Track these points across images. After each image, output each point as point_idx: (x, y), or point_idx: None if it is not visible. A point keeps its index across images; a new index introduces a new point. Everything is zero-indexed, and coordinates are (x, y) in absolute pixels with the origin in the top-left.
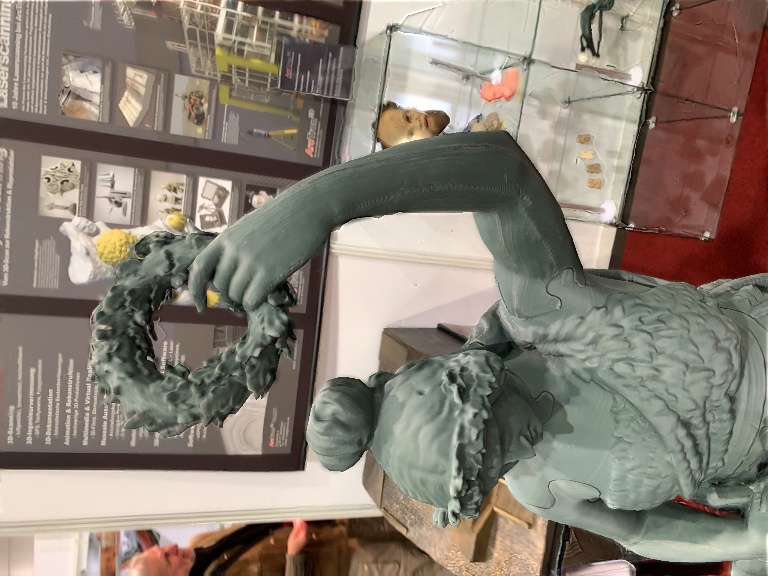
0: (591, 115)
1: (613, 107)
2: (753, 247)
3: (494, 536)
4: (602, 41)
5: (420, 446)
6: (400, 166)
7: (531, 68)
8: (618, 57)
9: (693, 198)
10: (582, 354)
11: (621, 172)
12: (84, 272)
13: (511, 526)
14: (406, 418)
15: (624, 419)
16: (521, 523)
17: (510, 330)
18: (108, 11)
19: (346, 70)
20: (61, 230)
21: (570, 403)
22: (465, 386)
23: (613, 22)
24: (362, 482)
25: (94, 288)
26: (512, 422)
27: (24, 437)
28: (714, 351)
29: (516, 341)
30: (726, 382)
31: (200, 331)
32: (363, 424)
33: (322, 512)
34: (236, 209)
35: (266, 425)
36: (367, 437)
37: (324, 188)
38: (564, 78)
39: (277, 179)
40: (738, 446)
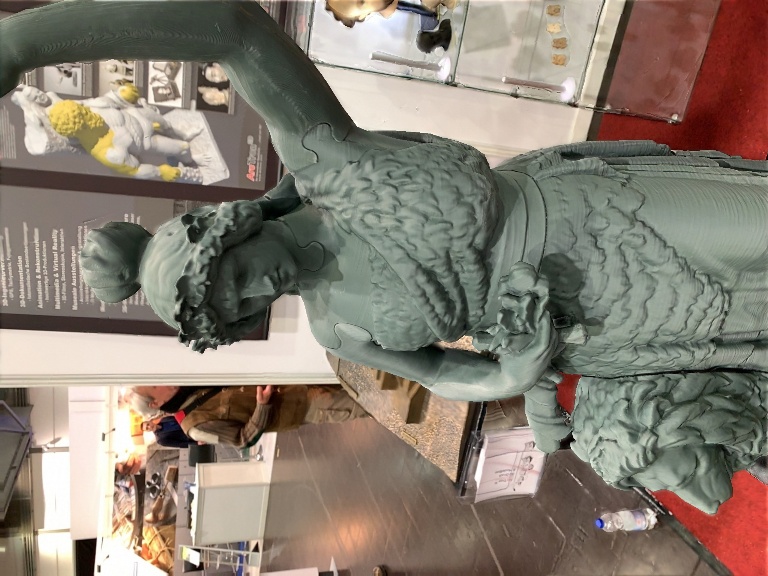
0: None
1: None
2: (716, 131)
3: (427, 401)
4: None
5: (159, 279)
6: (88, 11)
7: None
8: None
9: (681, 79)
10: (339, 206)
11: (603, 49)
12: (40, 143)
13: None
14: (153, 255)
15: (377, 267)
16: None
17: (295, 185)
18: None
19: None
20: (13, 100)
21: (340, 253)
22: (198, 227)
23: None
24: (326, 353)
25: (52, 159)
26: (255, 263)
27: (0, 299)
28: (454, 205)
29: None
30: (467, 235)
31: (159, 205)
32: (121, 260)
33: (288, 378)
34: (189, 81)
35: None
36: (129, 272)
37: (4, 30)
38: None
39: None
40: (496, 297)
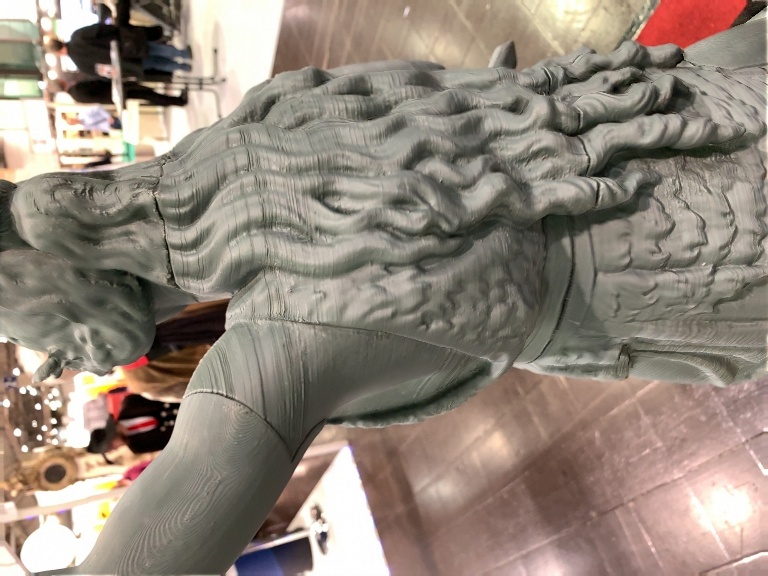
0: None
1: None
2: None
3: None
4: None
5: None
6: None
7: None
8: None
9: None
10: None
11: None
12: None
13: None
14: None
15: None
16: None
17: None
18: None
19: None
20: None
21: None
22: None
23: None
24: None
25: None
26: None
27: None
28: None
29: None
30: None
31: None
32: None
33: None
34: None
35: None
36: None
37: None
38: None
39: None
40: None
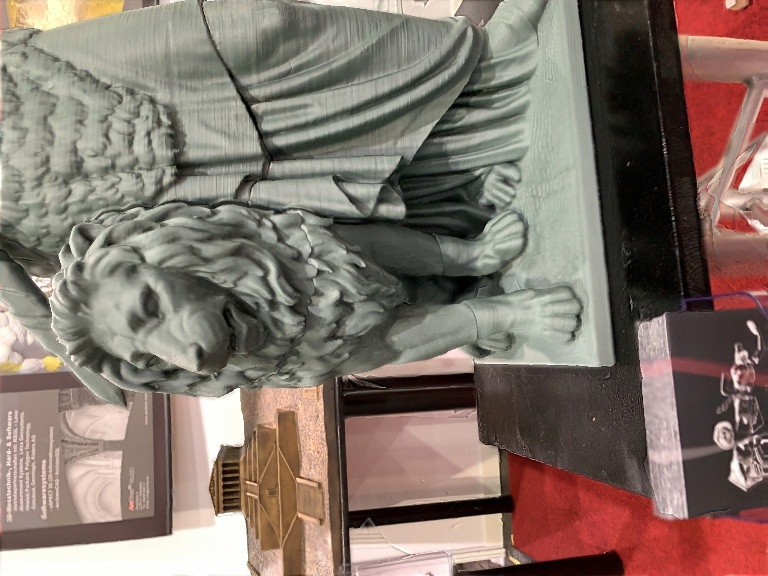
0: None
1: None
2: None
3: (304, 548)
4: None
5: None
6: None
7: None
8: None
9: None
10: None
11: None
12: None
13: (313, 530)
14: None
15: None
16: (316, 522)
17: None
18: None
19: None
20: None
21: None
22: None
23: None
24: None
25: None
26: None
27: None
28: None
29: None
30: None
31: (43, 396)
32: None
33: None
34: None
35: (123, 487)
36: None
37: None
38: None
39: None
40: None
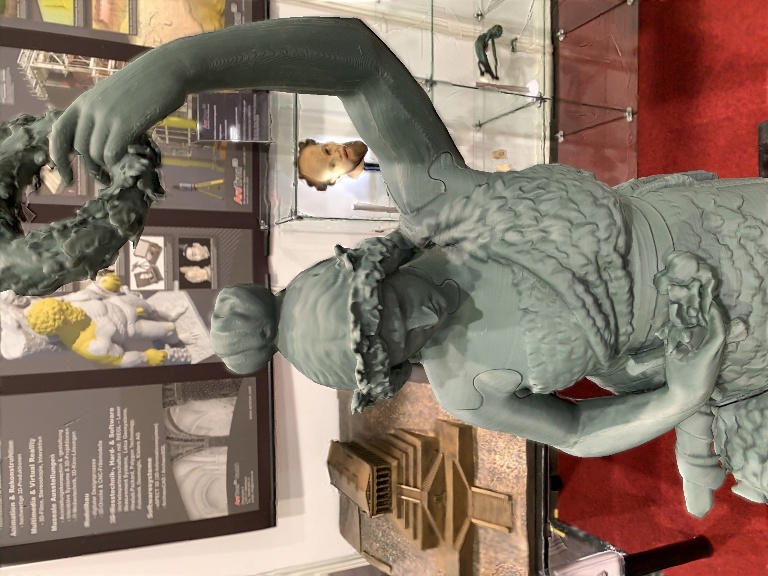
0: (503, 136)
1: (522, 127)
2: None
3: (477, 550)
4: (498, 65)
5: (319, 317)
6: (250, 31)
7: (434, 89)
8: (516, 78)
9: None
10: (474, 232)
11: None
12: (17, 346)
13: (492, 535)
14: (303, 298)
15: (525, 288)
16: (501, 529)
17: (409, 234)
18: (20, 86)
19: (262, 115)
20: None
21: (475, 289)
22: (355, 254)
23: (505, 48)
24: (339, 531)
25: (29, 362)
26: (411, 292)
27: None
28: (593, 207)
29: (416, 243)
30: (612, 236)
31: (147, 392)
32: (263, 314)
33: (302, 571)
34: (171, 264)
35: (229, 483)
36: (270, 329)
37: (174, 47)
38: (471, 105)
39: (209, 229)
40: (642, 309)
